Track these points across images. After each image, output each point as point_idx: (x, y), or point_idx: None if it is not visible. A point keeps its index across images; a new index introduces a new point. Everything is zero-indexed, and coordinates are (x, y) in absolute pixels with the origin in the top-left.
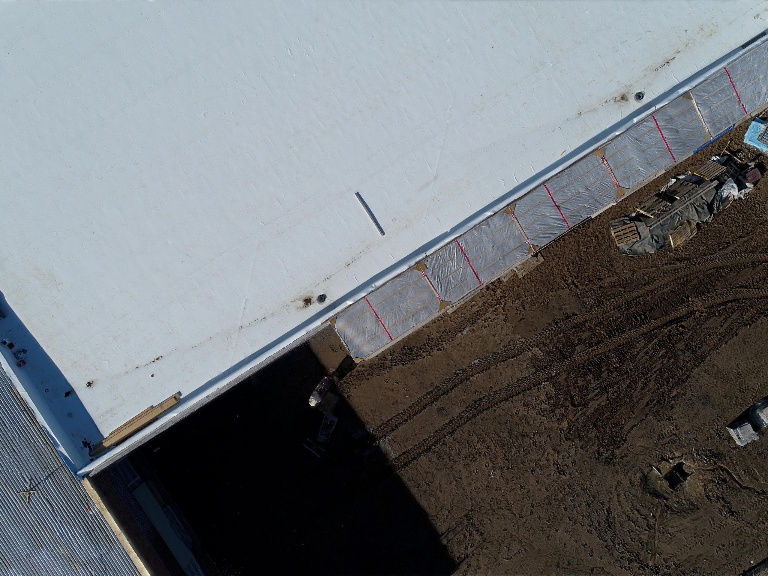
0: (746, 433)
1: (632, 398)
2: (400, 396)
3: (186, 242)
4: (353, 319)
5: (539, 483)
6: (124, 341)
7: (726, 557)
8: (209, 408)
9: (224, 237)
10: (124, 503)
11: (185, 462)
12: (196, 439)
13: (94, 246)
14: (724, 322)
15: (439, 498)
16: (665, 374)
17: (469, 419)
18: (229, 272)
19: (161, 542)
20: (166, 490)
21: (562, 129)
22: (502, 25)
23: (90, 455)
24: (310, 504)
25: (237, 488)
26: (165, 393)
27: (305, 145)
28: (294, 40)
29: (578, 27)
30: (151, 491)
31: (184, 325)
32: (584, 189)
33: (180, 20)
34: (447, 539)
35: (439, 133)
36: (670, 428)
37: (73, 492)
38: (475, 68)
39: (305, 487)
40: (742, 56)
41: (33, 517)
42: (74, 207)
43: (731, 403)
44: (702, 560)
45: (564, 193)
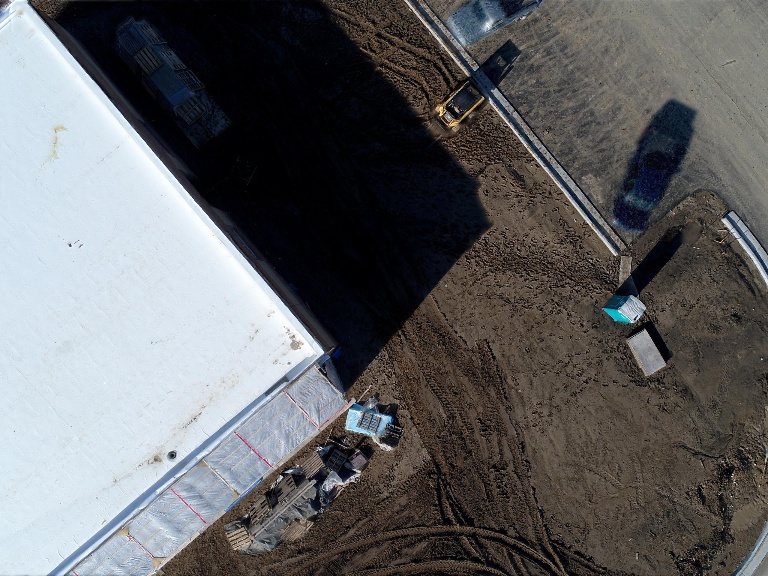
0: None
1: None
2: None
3: None
4: None
5: None
6: None
7: None
8: None
9: None
10: None
11: None
12: None
13: None
14: None
15: None
16: None
17: None
18: None
19: None
20: None
21: (99, 499)
22: (20, 409)
23: None
24: None
25: None
26: None
27: None
28: None
29: (98, 398)
30: None
31: None
32: (117, 567)
33: None
34: None
35: None
36: None
37: None
38: (0, 454)
39: None
40: (250, 418)
41: None
42: None
43: None
44: None
45: (96, 575)
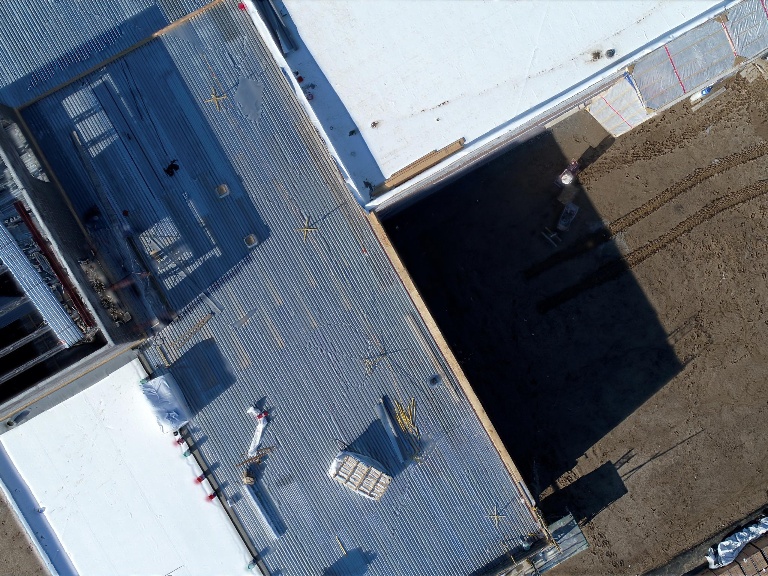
0: None
1: None
2: (639, 191)
3: None
4: (650, 67)
5: None
6: (412, 83)
7: None
8: (449, 191)
9: None
10: None
11: (422, 244)
12: (434, 222)
13: None
14: None
15: (670, 297)
16: None
17: (706, 219)
18: (521, 20)
19: None
20: None
21: None
22: None
23: (371, 195)
24: (543, 295)
25: (472, 274)
26: (449, 138)
27: None
28: None
29: None
30: None
31: (473, 71)
32: None
33: None
34: (675, 339)
35: None
36: None
37: (350, 233)
38: None
39: (539, 277)
40: None
41: (309, 255)
42: None
43: None
44: None
45: None
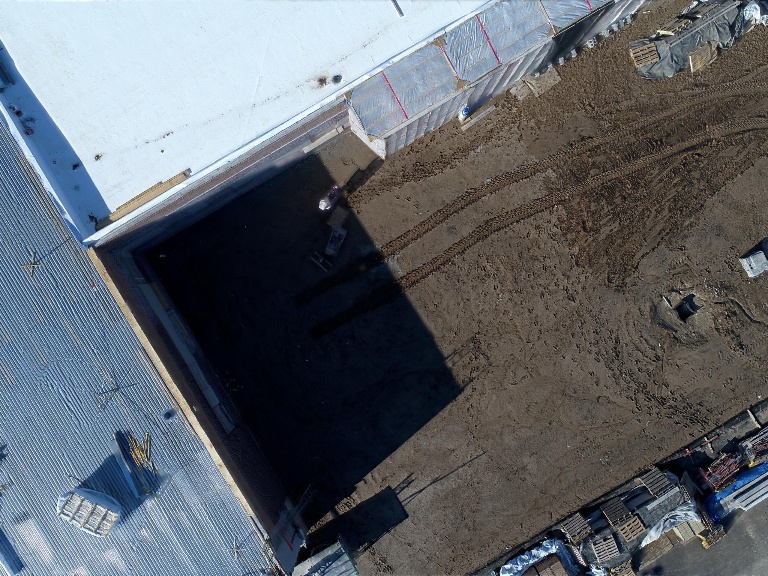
0: (759, 261)
1: (645, 226)
2: (410, 213)
3: (201, 14)
4: (369, 94)
5: (548, 308)
6: (135, 114)
7: (733, 391)
8: (217, 218)
9: (240, 11)
10: (129, 286)
11: (190, 272)
12: (202, 249)
13: (107, 14)
14: (741, 151)
15: (446, 319)
16: (679, 202)
17: (479, 239)
18: (244, 48)
19: (165, 332)
20: (170, 299)
21: None
22: None
23: (96, 229)
24: (316, 320)
25: (242, 301)
26: (175, 170)
27: None
28: None
29: None
30: (155, 293)
31: (196, 100)
32: None
33: None
34: (453, 362)
35: None
36: (682, 258)
37: (78, 268)
38: None
39: (311, 302)
40: None
41: (36, 291)
42: None
43: (744, 235)
44: (709, 393)
45: None
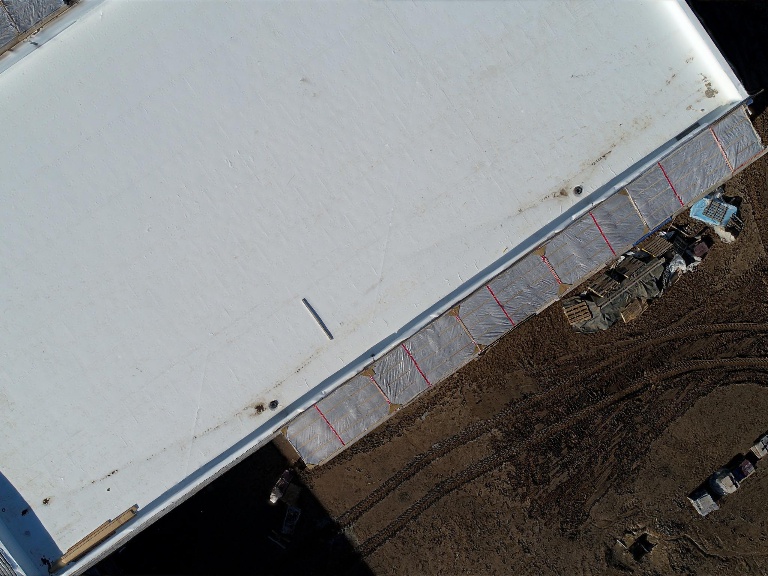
0: (706, 504)
1: (593, 473)
2: (363, 483)
3: (136, 356)
4: (304, 427)
5: (505, 562)
6: (79, 457)
7: None
8: None
9: (174, 349)
10: None
11: (151, 560)
12: (161, 536)
13: (44, 365)
14: (680, 394)
15: None
16: (624, 448)
17: (432, 503)
18: (180, 383)
19: None
20: None
21: (503, 226)
22: (439, 128)
23: (49, 572)
24: None
25: None
26: (122, 506)
27: (250, 255)
28: (234, 152)
29: (514, 126)
30: None
31: (138, 438)
32: (527, 288)
33: (120, 138)
34: None
35: (382, 236)
36: (632, 501)
37: None
38: (414, 171)
39: None
40: (675, 151)
41: None
42: (23, 327)
43: (691, 473)
44: None
45: (507, 293)
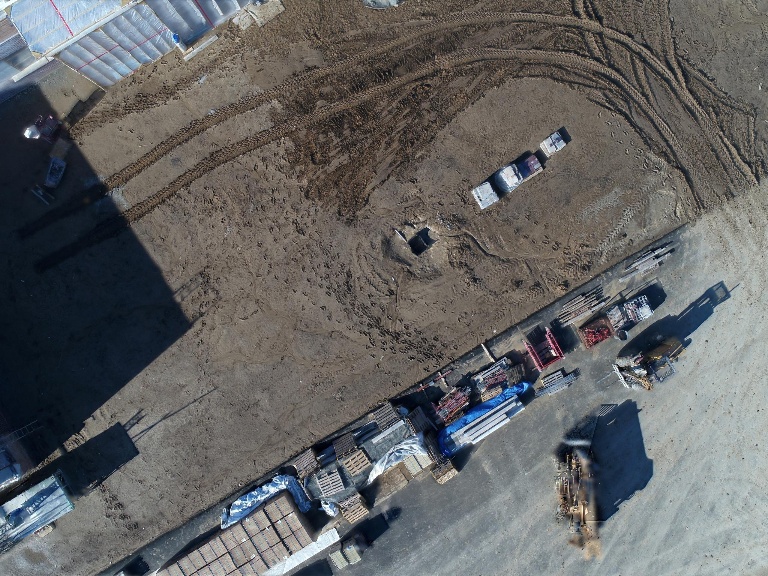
0: (485, 192)
1: (375, 158)
2: (134, 145)
3: None
4: (30, 9)
5: (277, 242)
6: None
7: (468, 325)
8: None
9: None
10: None
11: None
12: None
13: None
14: (471, 82)
15: (174, 253)
16: (410, 134)
17: (205, 172)
18: None
19: None
20: None
21: None
22: None
23: None
24: (40, 254)
25: None
26: None
27: None
28: None
29: None
30: None
31: None
32: None
33: None
34: (181, 296)
35: None
36: (414, 191)
37: None
38: None
39: (34, 236)
40: None
41: None
42: None
43: (477, 167)
44: (444, 328)
45: None
